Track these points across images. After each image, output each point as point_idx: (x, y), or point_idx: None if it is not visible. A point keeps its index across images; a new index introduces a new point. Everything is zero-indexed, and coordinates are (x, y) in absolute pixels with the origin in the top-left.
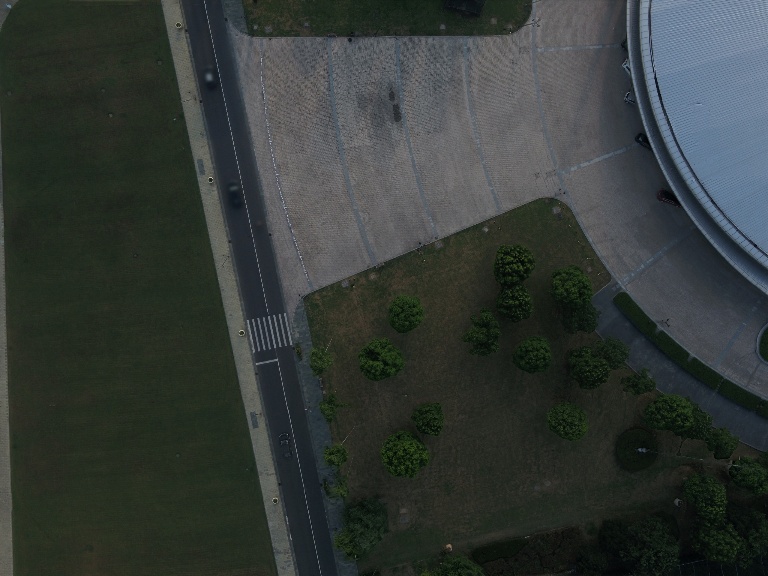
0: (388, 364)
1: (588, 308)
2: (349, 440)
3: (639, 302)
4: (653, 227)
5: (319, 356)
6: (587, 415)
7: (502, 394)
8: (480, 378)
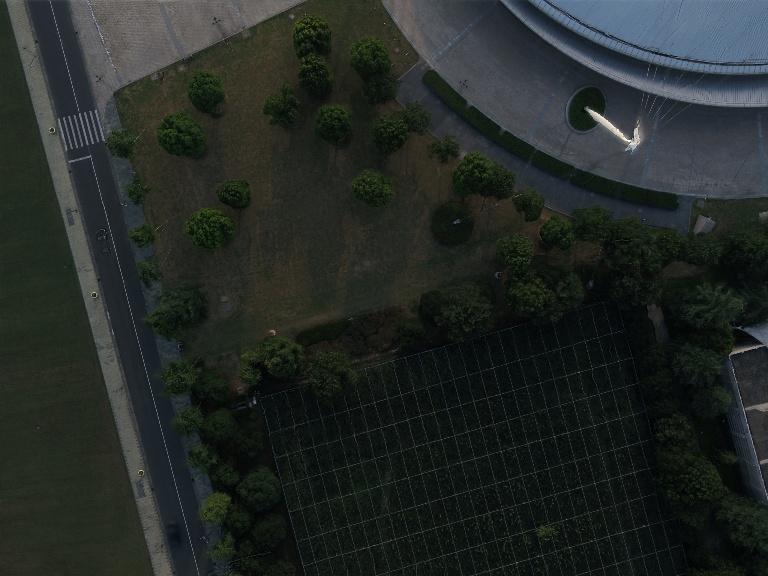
0: (182, 131)
1: (386, 74)
2: (166, 231)
3: (448, 80)
4: (457, 5)
5: (120, 136)
6: (402, 193)
7: (316, 176)
8: (293, 161)
